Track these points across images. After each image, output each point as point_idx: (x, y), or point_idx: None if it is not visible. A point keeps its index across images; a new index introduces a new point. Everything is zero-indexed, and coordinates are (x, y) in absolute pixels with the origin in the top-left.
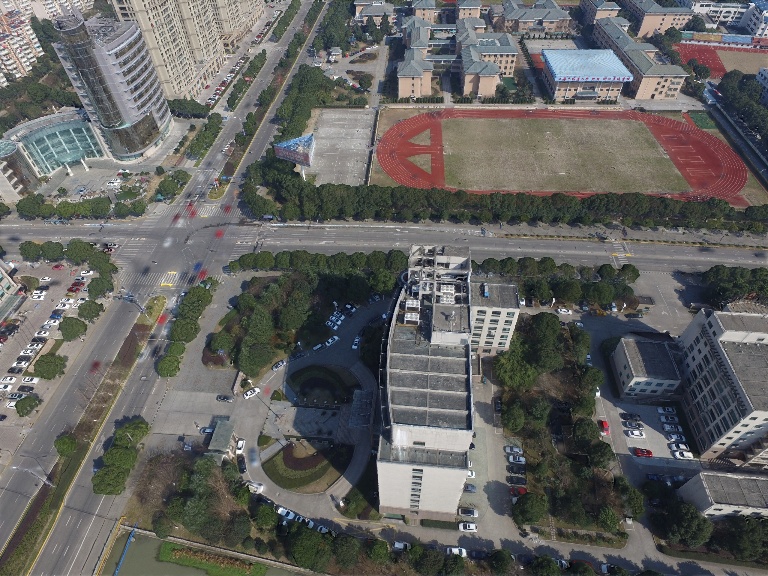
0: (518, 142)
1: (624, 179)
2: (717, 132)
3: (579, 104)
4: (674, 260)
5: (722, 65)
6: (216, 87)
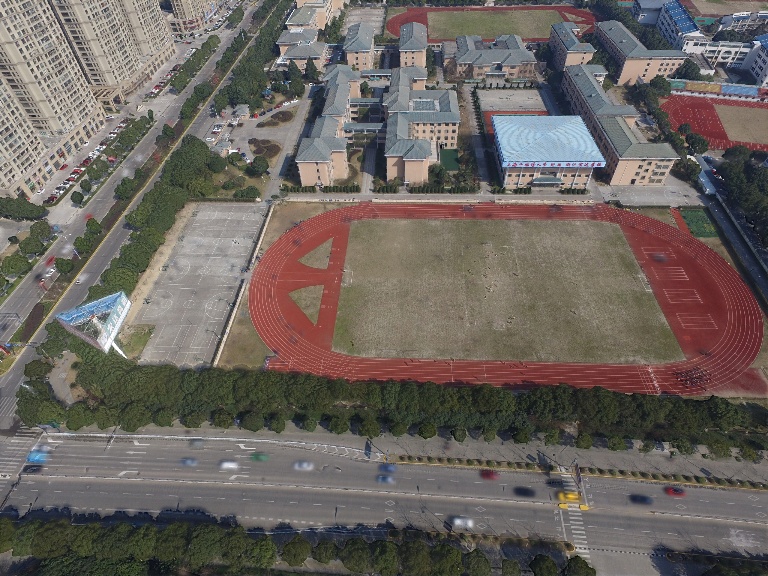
0: (447, 263)
1: (587, 335)
2: (718, 243)
3: (536, 194)
4: (656, 520)
5: (722, 128)
6: (74, 167)
